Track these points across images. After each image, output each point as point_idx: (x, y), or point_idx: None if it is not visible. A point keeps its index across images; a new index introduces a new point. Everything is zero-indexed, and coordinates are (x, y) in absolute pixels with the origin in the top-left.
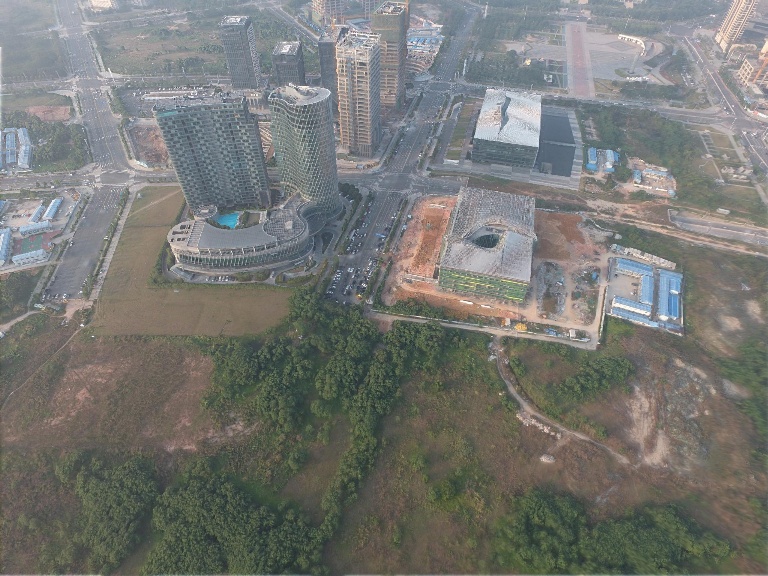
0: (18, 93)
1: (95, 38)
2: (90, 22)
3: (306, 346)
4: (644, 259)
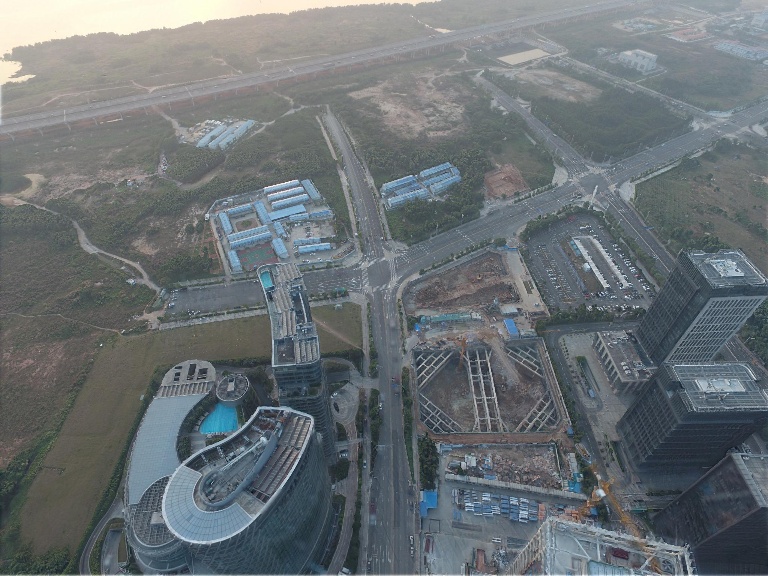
0: (539, 148)
1: (717, 147)
2: (763, 128)
3: None
4: None
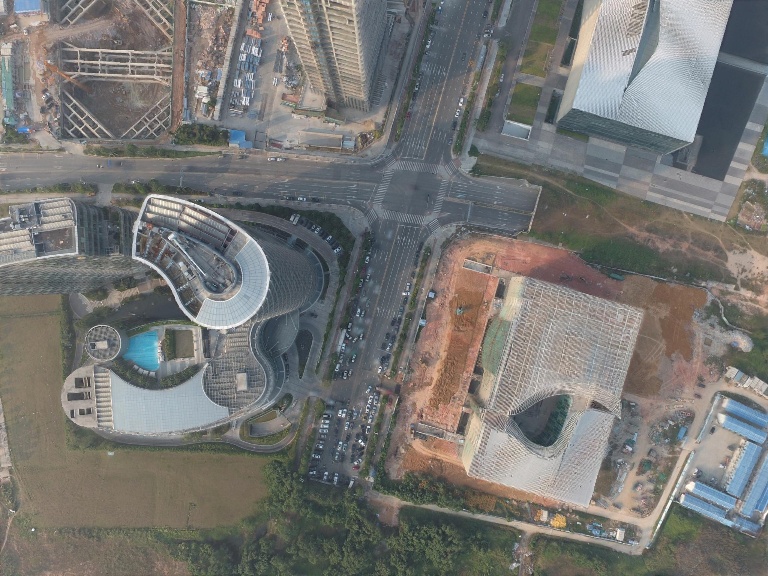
0: None
1: None
2: None
3: (294, 559)
4: (766, 398)
